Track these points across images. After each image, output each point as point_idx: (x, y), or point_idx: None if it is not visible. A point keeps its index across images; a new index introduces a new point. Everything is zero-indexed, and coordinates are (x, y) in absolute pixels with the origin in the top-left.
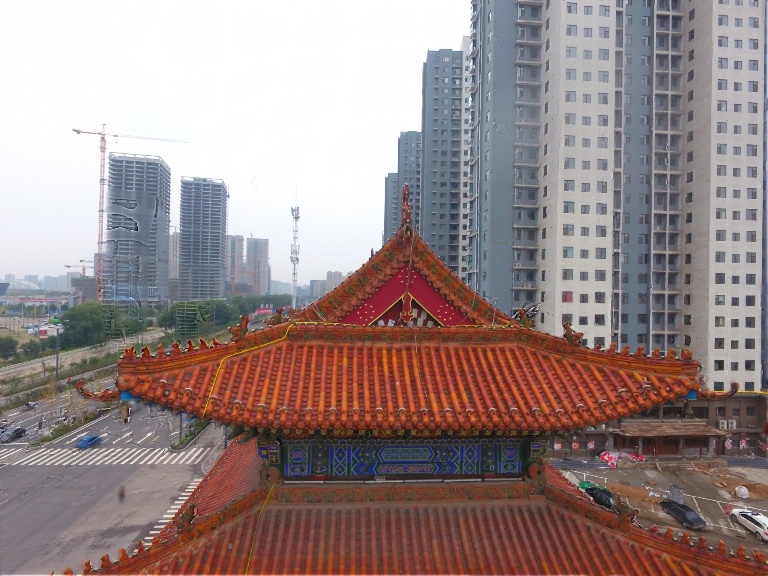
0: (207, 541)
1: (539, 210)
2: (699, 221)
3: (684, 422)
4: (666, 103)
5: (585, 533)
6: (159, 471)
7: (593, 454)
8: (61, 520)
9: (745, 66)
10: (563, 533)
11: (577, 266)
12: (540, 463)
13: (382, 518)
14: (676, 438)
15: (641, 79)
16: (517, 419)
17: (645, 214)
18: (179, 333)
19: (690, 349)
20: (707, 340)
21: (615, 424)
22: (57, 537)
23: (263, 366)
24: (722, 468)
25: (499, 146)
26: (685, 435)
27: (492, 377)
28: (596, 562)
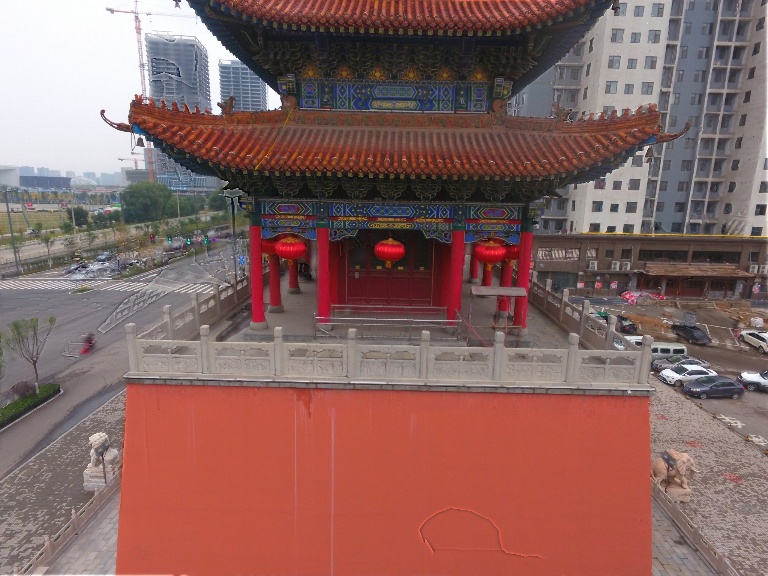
0: (244, 129)
1: (586, 44)
2: (767, 50)
3: (713, 265)
4: None
5: (530, 138)
6: None
7: (615, 294)
8: (145, 319)
9: None
10: (513, 140)
11: (619, 103)
12: (503, 100)
13: (373, 133)
14: (702, 281)
15: None
16: (473, 18)
17: (706, 47)
18: (227, 182)
19: (733, 195)
20: (752, 184)
21: (641, 266)
22: (143, 327)
23: (278, 1)
24: (744, 308)
25: None
26: (711, 276)
27: (463, 11)
28: (533, 148)
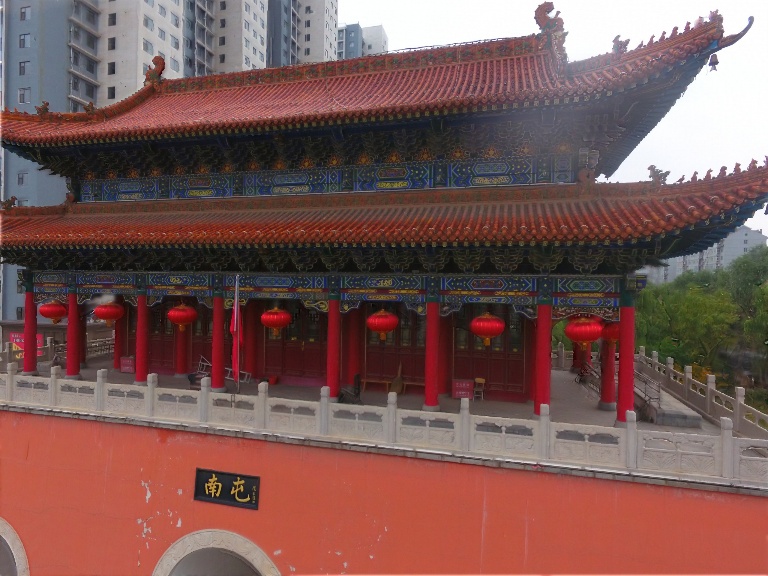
0: None
1: None
2: None
3: None
4: (203, 55)
5: None
6: None
7: None
8: None
9: (258, 54)
10: None
11: None
12: None
13: None
14: None
15: (186, 21)
16: None
17: None
18: None
19: None
20: None
21: None
22: None
23: None
24: None
25: (47, 9)
26: None
27: None
28: None
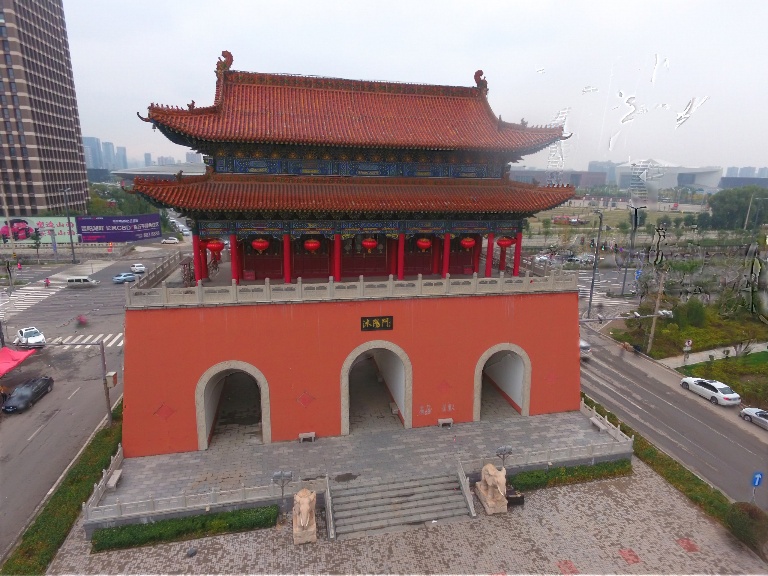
0: None
1: None
2: None
3: None
4: None
5: None
6: None
7: None
8: None
9: None
10: None
11: None
12: None
13: None
14: None
15: None
16: None
17: None
18: (633, 192)
19: None
20: None
21: None
22: None
23: None
24: None
25: None
26: None
27: None
28: None
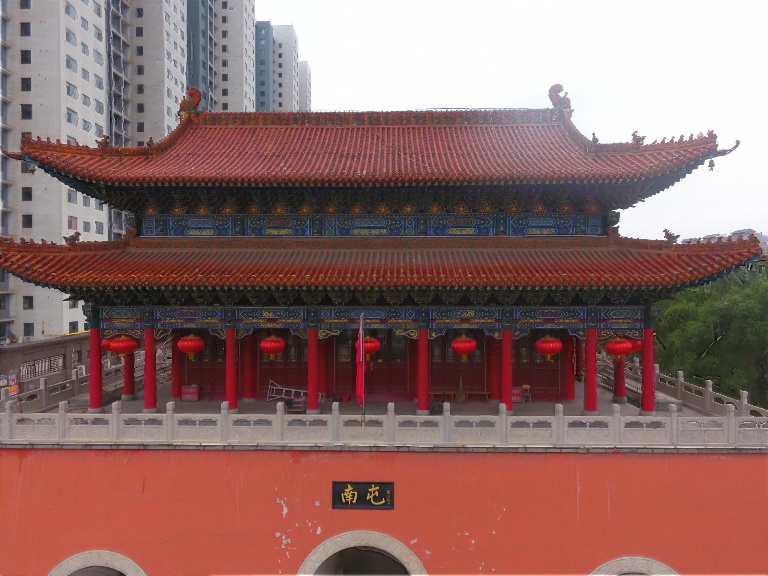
0: None
1: (11, 106)
2: None
3: None
4: (119, 45)
5: None
6: None
7: None
8: None
9: (179, 49)
10: None
11: None
12: None
13: None
14: None
15: None
16: None
17: None
18: None
19: None
20: None
21: (115, 361)
22: None
23: None
24: None
25: None
26: None
27: None
28: None
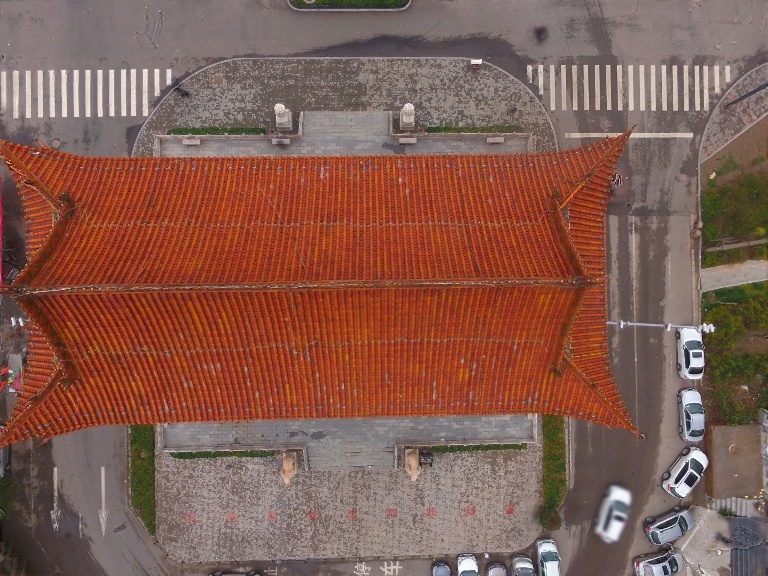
0: None
1: None
2: None
3: None
4: None
5: None
6: (758, 8)
7: None
8: None
9: None
10: None
11: None
12: None
13: None
14: None
15: None
16: None
17: None
18: None
19: None
20: None
21: None
22: None
23: None
24: None
25: None
26: None
27: None
28: None
